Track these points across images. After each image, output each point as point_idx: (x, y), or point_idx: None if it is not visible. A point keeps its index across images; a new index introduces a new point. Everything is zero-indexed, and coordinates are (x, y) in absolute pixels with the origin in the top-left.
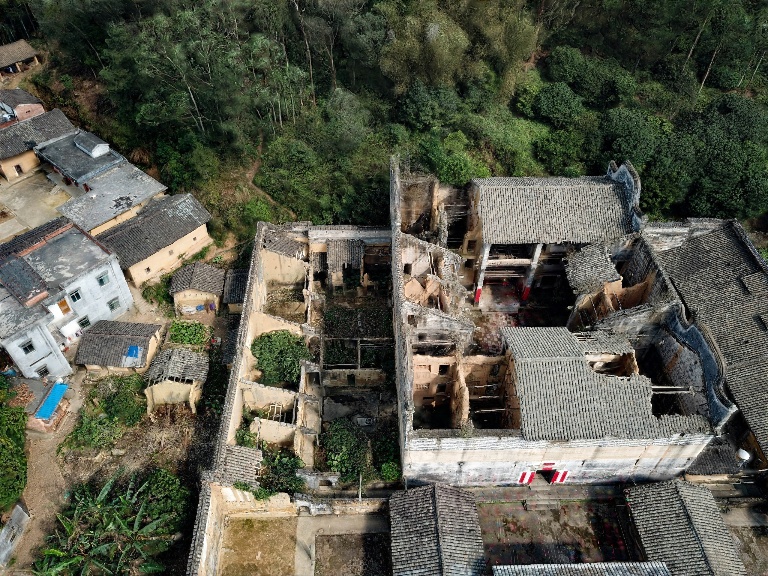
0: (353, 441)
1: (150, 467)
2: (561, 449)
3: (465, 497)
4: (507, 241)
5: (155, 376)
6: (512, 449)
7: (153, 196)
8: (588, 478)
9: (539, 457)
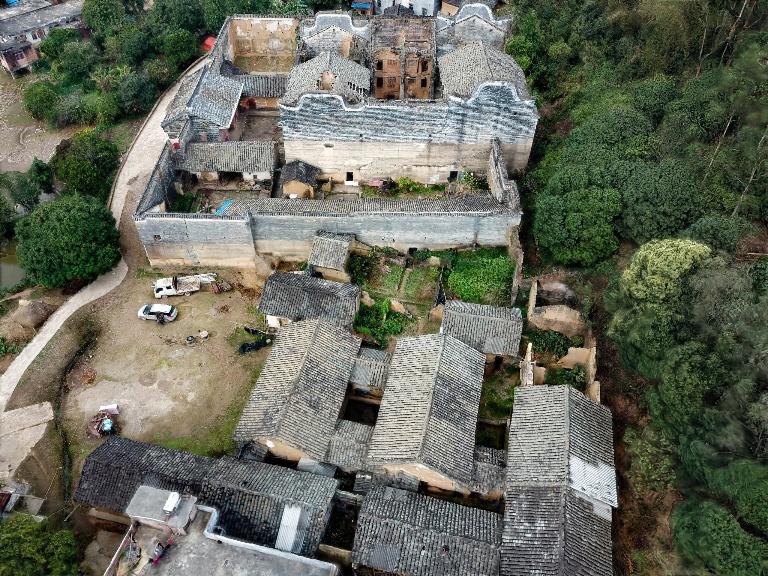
0: None
1: None
2: None
3: None
4: (440, 64)
5: None
6: None
7: None
8: None
9: None
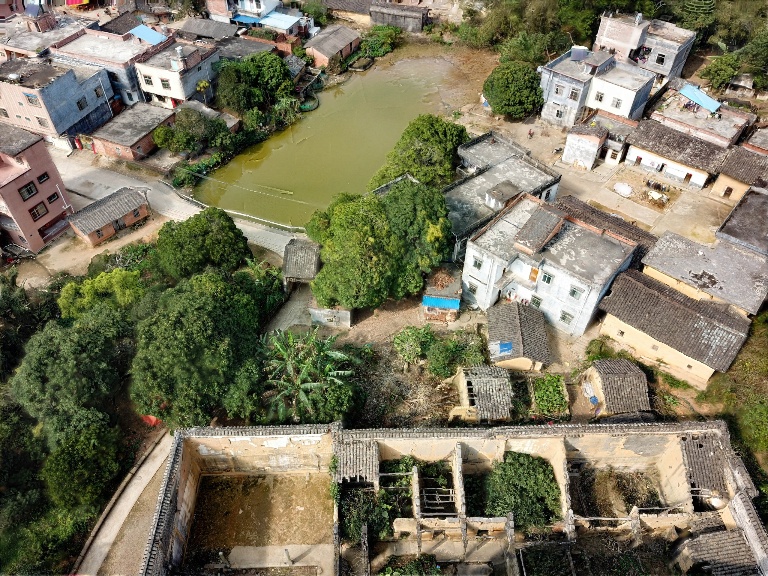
0: None
1: (386, 395)
2: None
3: None
4: None
5: (475, 371)
6: None
7: (733, 305)
8: None
9: None
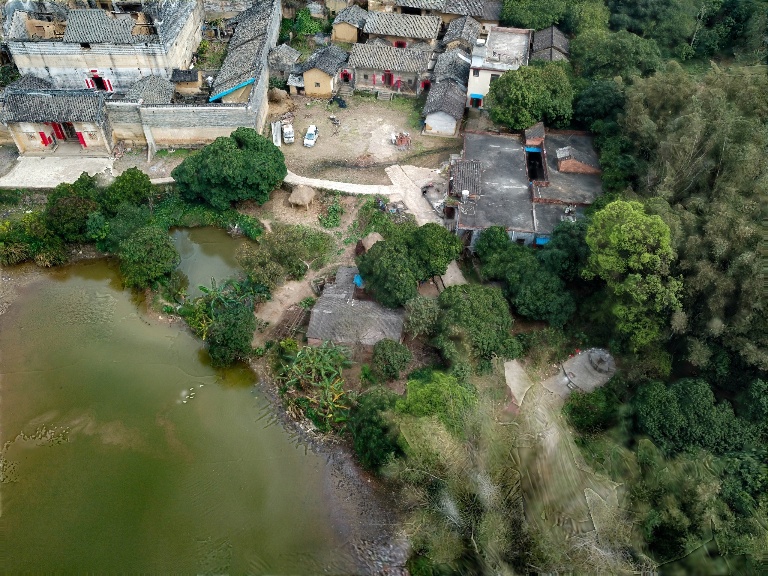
0: (8, 73)
1: None
2: (92, 57)
3: (46, 83)
4: None
5: None
6: (66, 55)
7: None
8: (124, 88)
9: (85, 64)
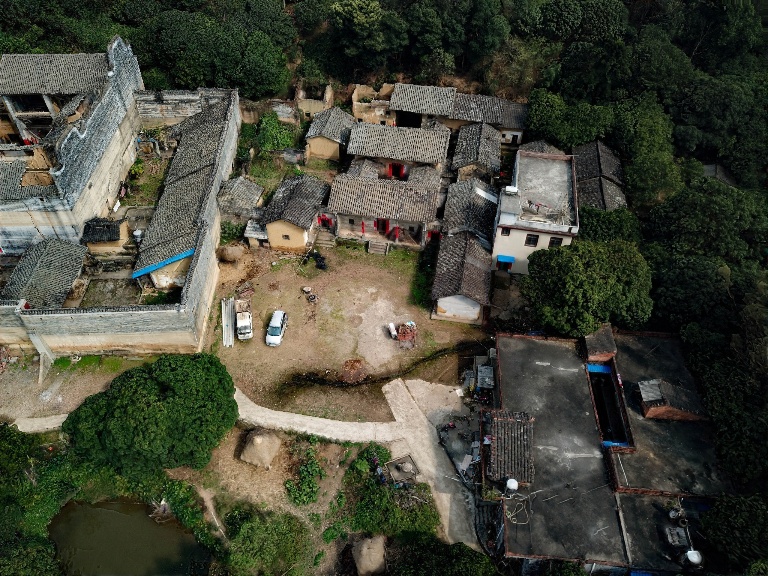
0: None
1: None
2: None
3: None
4: (11, 92)
5: None
6: None
7: None
8: (19, 248)
9: None
